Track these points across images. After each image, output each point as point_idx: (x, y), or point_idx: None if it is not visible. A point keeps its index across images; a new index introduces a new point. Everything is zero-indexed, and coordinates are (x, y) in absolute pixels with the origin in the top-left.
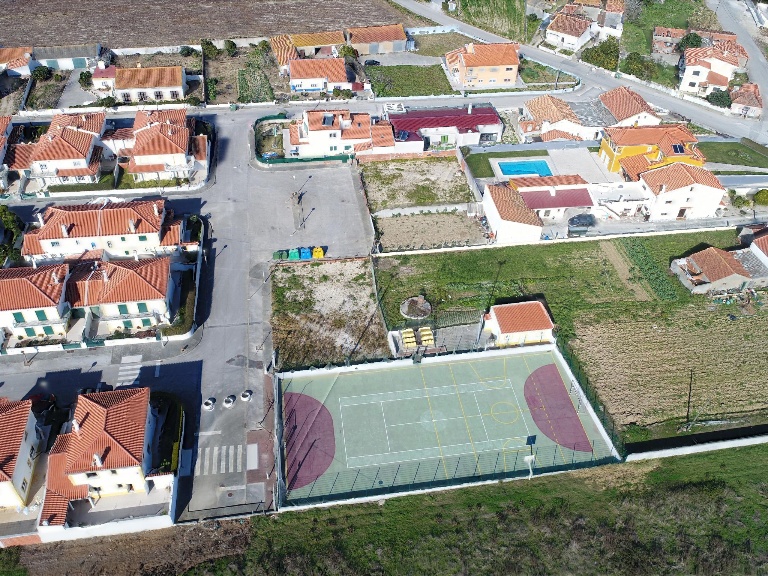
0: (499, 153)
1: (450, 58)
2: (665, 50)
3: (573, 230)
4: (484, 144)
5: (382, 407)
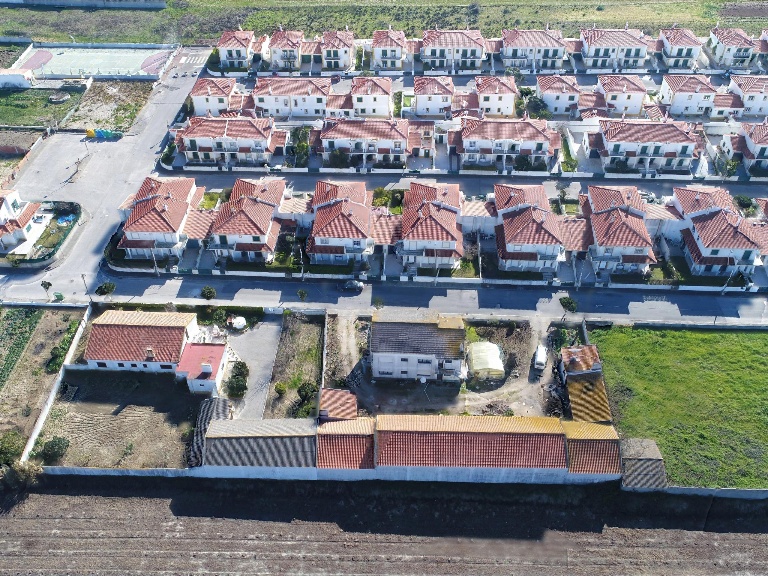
0: None
1: None
2: None
3: None
4: None
5: (116, 66)
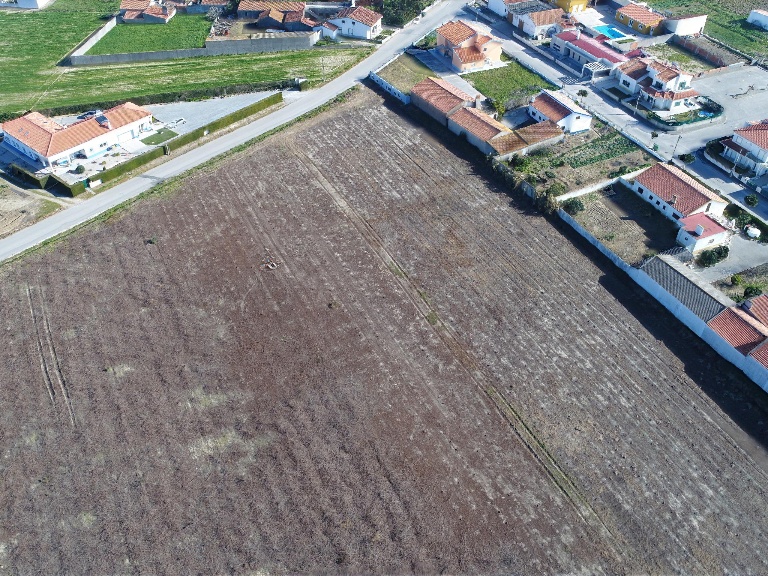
0: None
1: (472, 59)
2: None
3: None
4: None
5: None
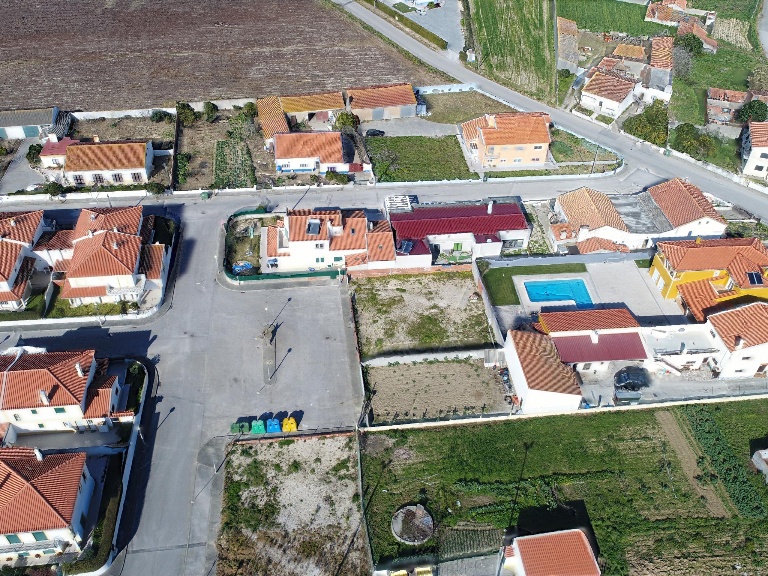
0: (525, 268)
1: (467, 130)
2: (722, 117)
3: (621, 397)
4: (506, 252)
5: None
